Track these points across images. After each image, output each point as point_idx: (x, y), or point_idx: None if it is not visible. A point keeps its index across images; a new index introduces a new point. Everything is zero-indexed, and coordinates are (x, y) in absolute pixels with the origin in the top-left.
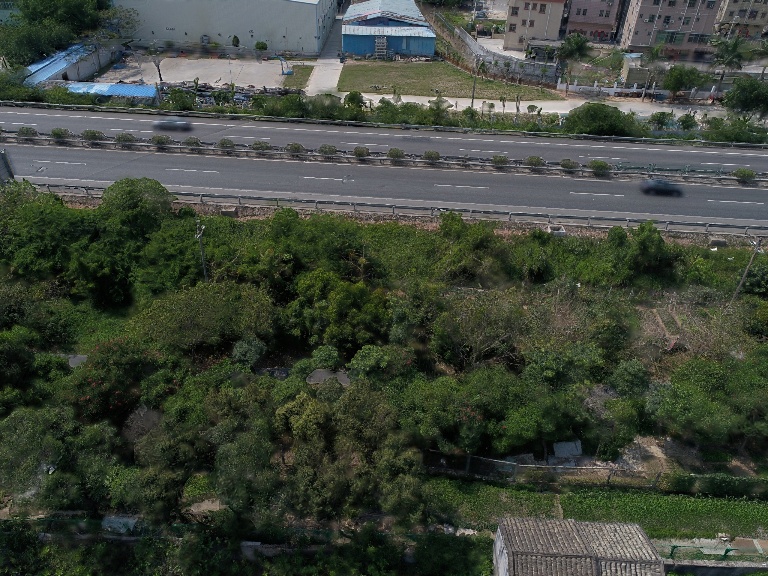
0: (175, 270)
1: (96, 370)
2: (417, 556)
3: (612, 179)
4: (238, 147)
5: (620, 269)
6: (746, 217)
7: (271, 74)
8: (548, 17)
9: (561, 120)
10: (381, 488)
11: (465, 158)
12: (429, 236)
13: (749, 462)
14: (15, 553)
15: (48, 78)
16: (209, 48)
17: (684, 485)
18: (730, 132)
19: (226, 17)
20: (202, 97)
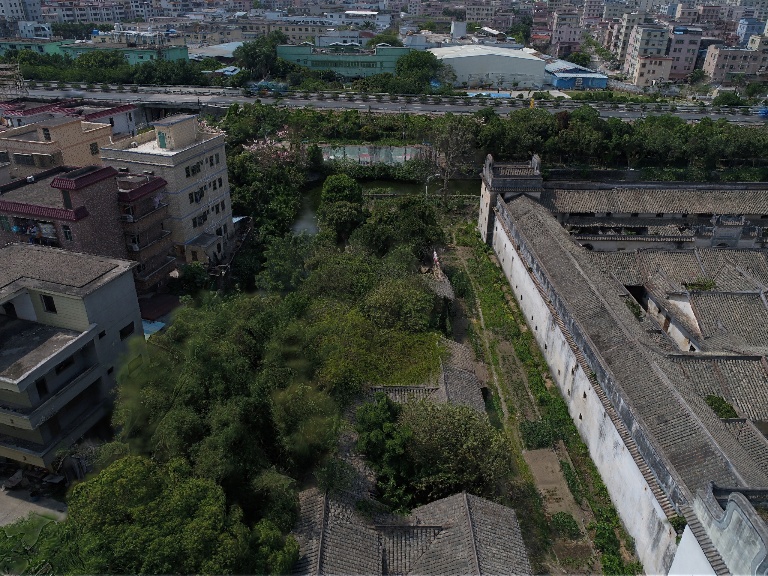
0: None
1: None
2: (760, 173)
3: None
4: None
5: None
6: None
7: None
8: (663, 68)
9: (708, 103)
10: (757, 144)
11: (687, 109)
12: None
13: None
14: None
15: None
16: (529, 76)
17: None
18: None
19: (495, 69)
20: None
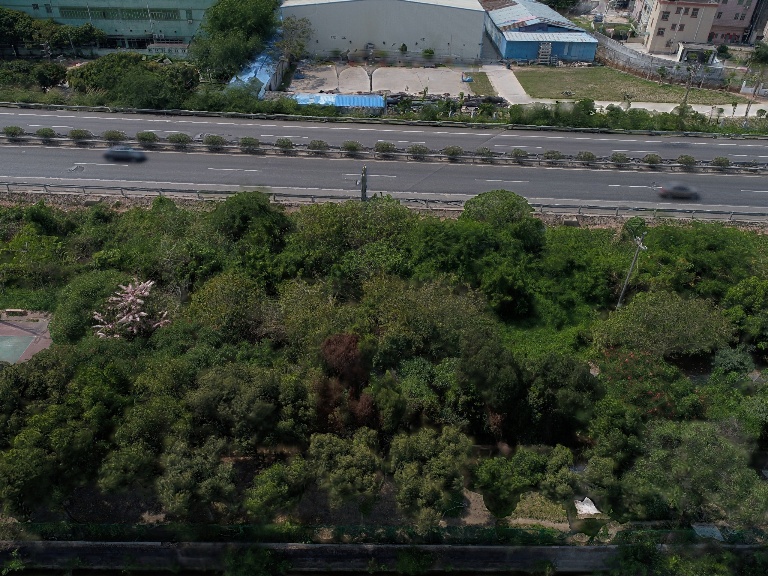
0: (588, 281)
1: (640, 382)
2: None
3: None
4: None
5: None
6: None
7: (452, 81)
8: (699, 21)
9: None
10: None
11: (751, 163)
12: None
13: None
14: (647, 564)
15: (265, 89)
16: (428, 57)
17: None
18: None
19: (393, 25)
20: None
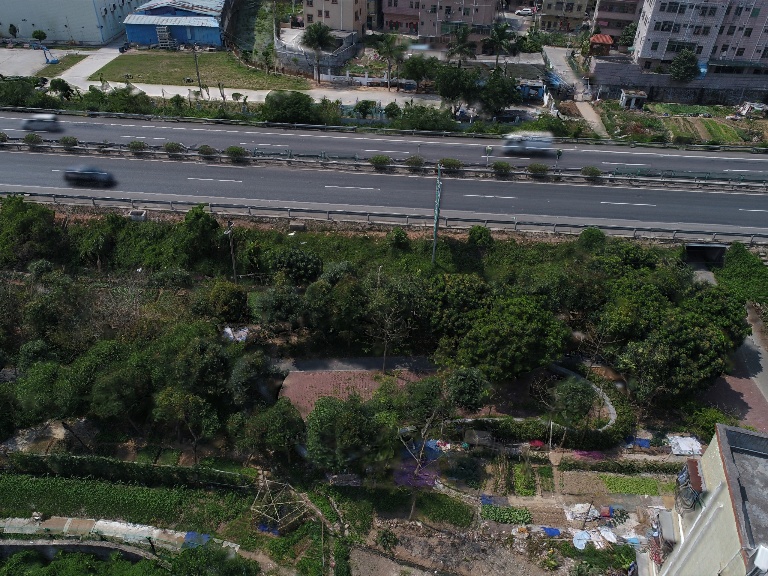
0: None
1: None
2: None
3: (247, 165)
4: None
5: (180, 253)
6: (347, 202)
7: (35, 63)
8: (341, 7)
9: None
10: None
11: (106, 144)
12: (1, 221)
13: (144, 442)
14: None
15: None
16: None
17: (35, 465)
18: (417, 120)
19: (3, 5)
20: None
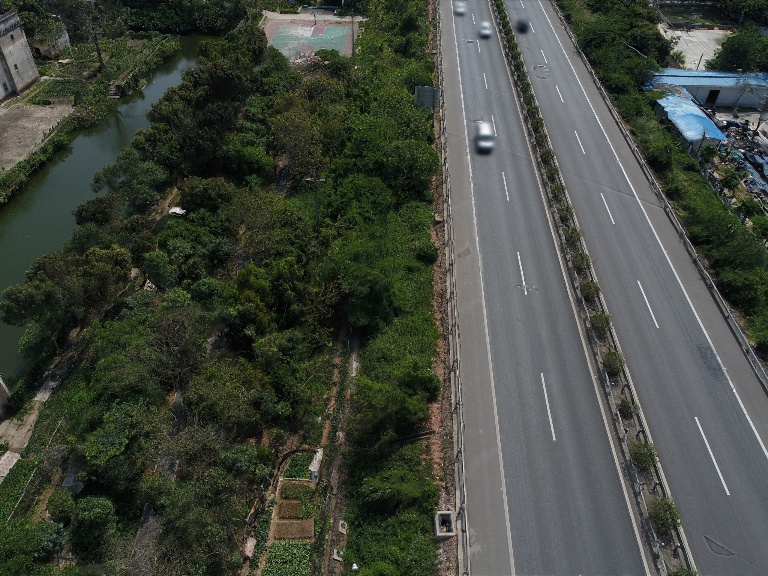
0: None
1: (202, 184)
2: None
3: None
4: (566, 202)
5: None
6: None
7: None
8: None
9: None
10: None
11: None
12: None
13: None
14: (129, 212)
15: (684, 85)
16: None
17: None
18: None
19: None
20: (762, 179)
